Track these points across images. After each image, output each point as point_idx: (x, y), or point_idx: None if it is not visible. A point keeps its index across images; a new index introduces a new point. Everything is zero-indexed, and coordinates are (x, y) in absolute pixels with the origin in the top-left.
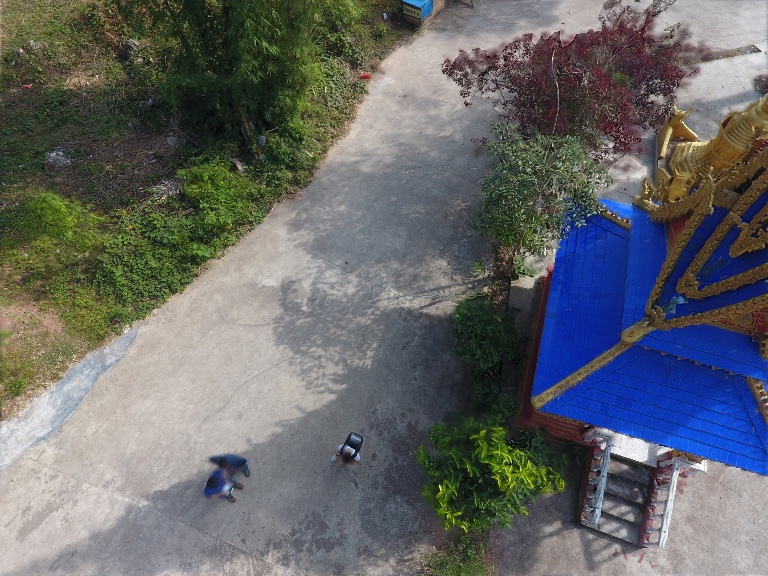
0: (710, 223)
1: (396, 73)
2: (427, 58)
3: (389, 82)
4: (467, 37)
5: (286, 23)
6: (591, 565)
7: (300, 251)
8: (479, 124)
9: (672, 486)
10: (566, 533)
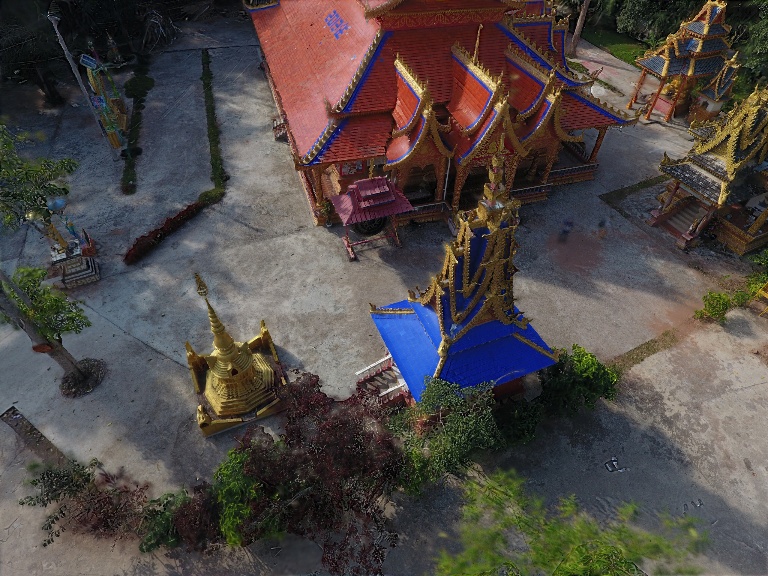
0: None
1: None
2: None
3: None
4: None
5: None
6: None
7: None
8: None
9: None
10: None
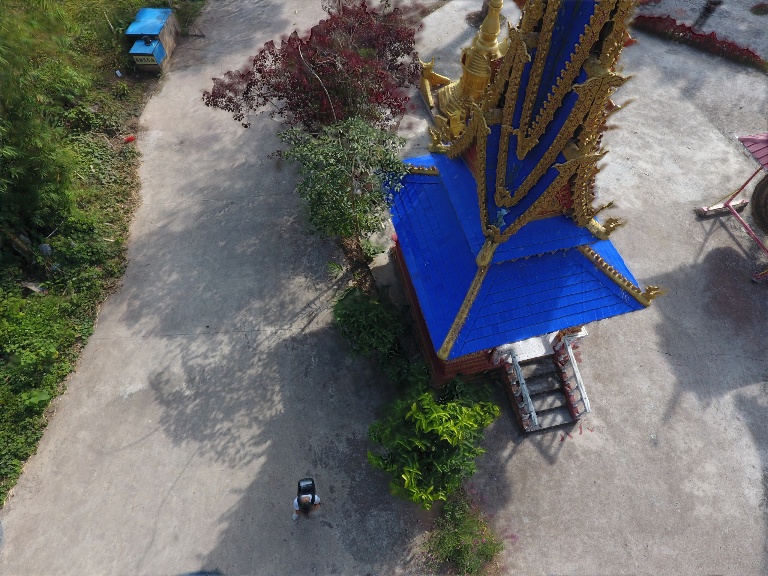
0: (493, 141)
1: (160, 124)
2: (184, 99)
3: (158, 136)
4: (213, 66)
5: (7, 116)
6: (551, 460)
7: (152, 340)
8: (267, 140)
9: (572, 360)
10: (520, 447)
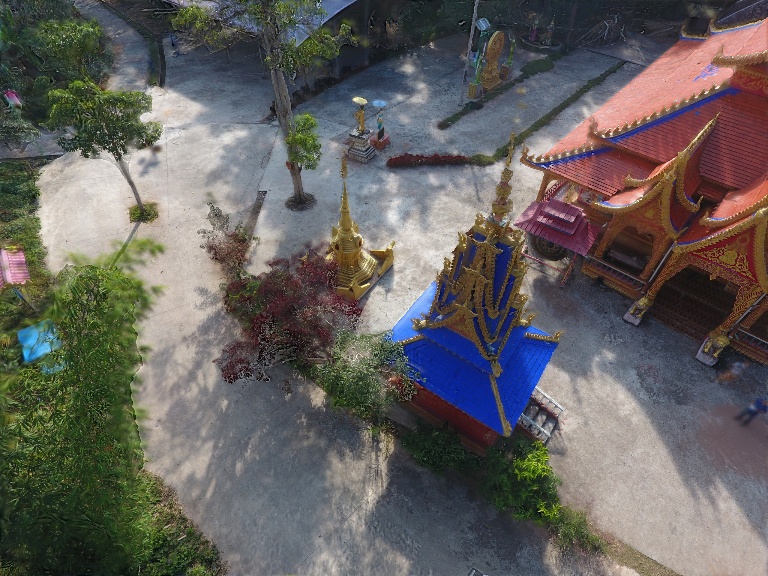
0: None
1: None
2: None
3: None
4: None
5: None
6: (564, 450)
7: None
8: None
9: (538, 390)
10: None
